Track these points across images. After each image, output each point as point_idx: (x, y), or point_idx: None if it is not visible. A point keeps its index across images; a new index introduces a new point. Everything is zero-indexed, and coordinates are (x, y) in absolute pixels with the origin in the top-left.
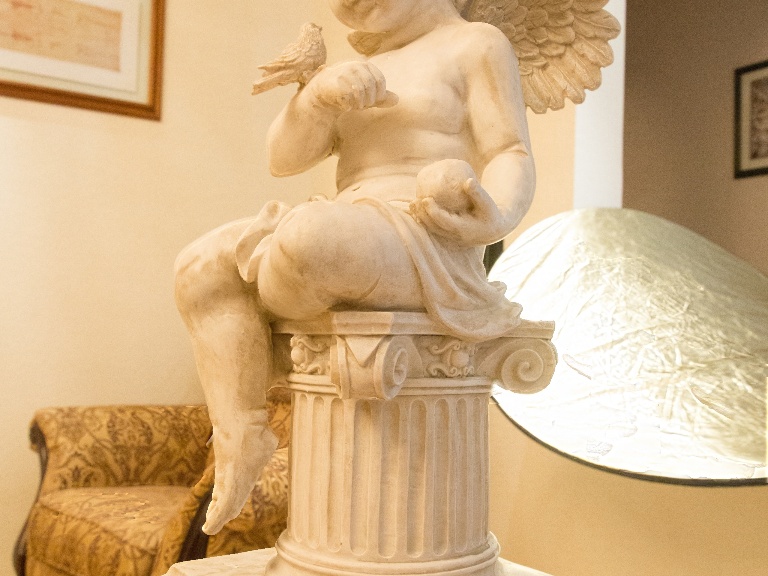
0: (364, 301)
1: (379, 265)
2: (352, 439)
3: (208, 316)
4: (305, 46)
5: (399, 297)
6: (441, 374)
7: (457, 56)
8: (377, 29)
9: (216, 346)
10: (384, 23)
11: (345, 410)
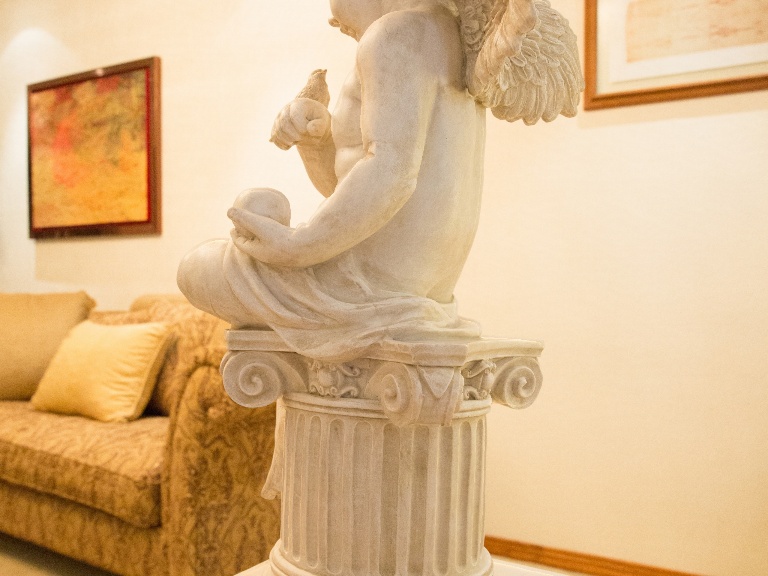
0: None
1: (206, 291)
2: (284, 441)
3: None
4: (297, 96)
5: (240, 317)
6: None
7: None
8: None
9: None
10: None
11: None
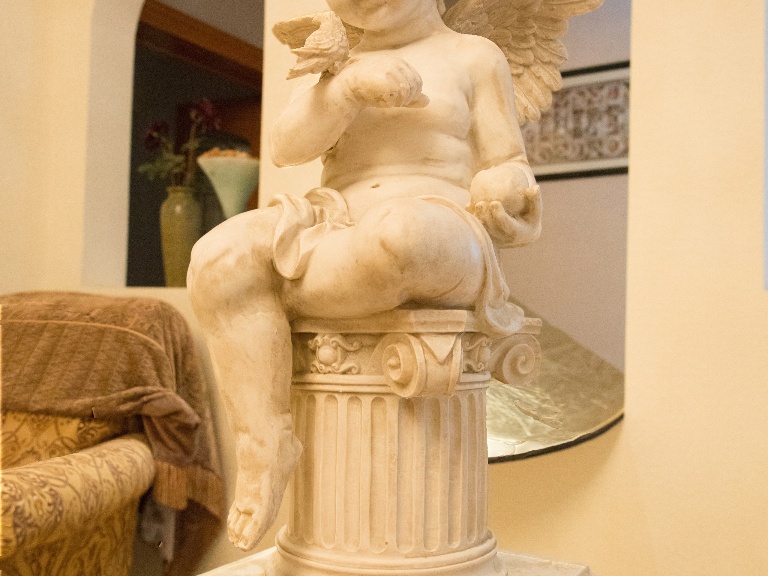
0: (439, 299)
1: (466, 264)
2: (396, 437)
3: (240, 314)
4: (337, 35)
5: (466, 296)
6: (468, 369)
7: (469, 66)
8: (377, 27)
9: (249, 347)
10: (386, 22)
11: (388, 409)
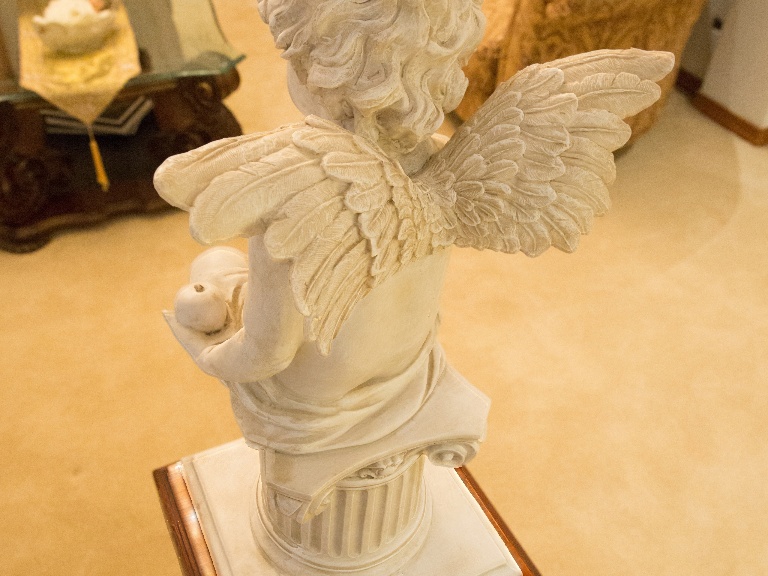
0: None
1: None
2: None
3: None
4: None
5: None
6: None
7: None
8: None
9: None
10: None
11: None
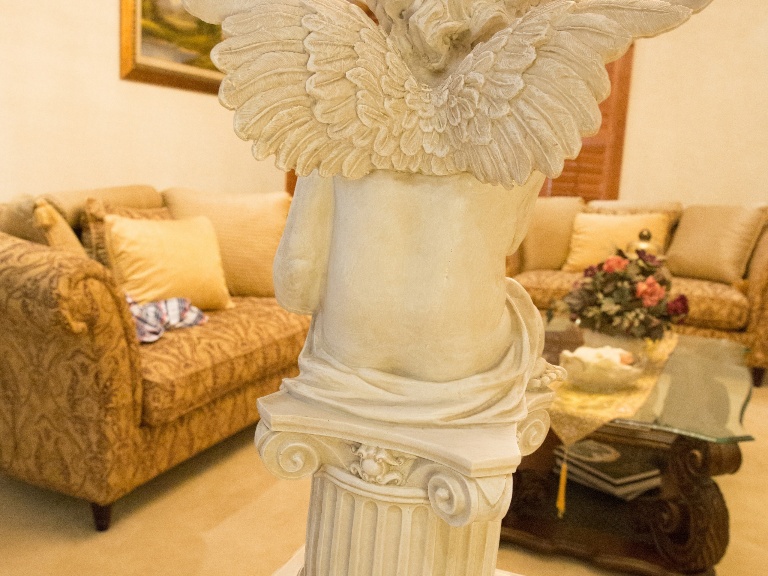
0: None
1: None
2: None
3: None
4: None
5: None
6: None
7: None
8: None
9: None
10: None
11: None
